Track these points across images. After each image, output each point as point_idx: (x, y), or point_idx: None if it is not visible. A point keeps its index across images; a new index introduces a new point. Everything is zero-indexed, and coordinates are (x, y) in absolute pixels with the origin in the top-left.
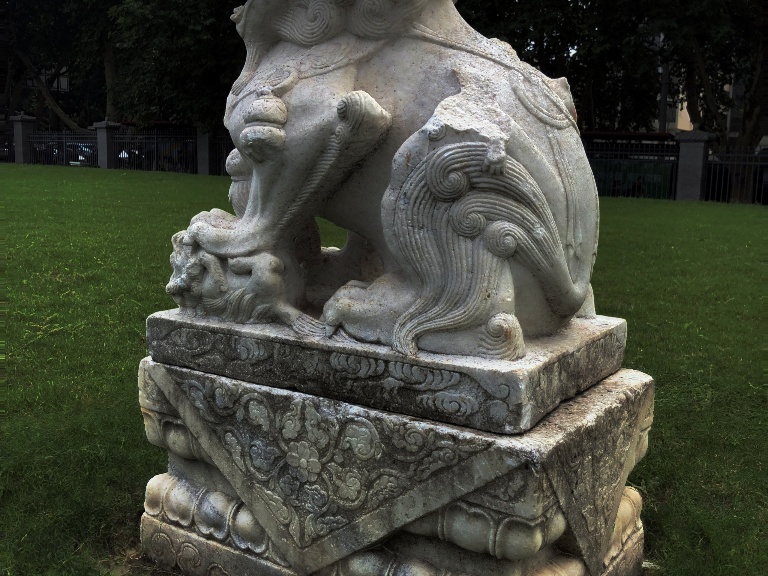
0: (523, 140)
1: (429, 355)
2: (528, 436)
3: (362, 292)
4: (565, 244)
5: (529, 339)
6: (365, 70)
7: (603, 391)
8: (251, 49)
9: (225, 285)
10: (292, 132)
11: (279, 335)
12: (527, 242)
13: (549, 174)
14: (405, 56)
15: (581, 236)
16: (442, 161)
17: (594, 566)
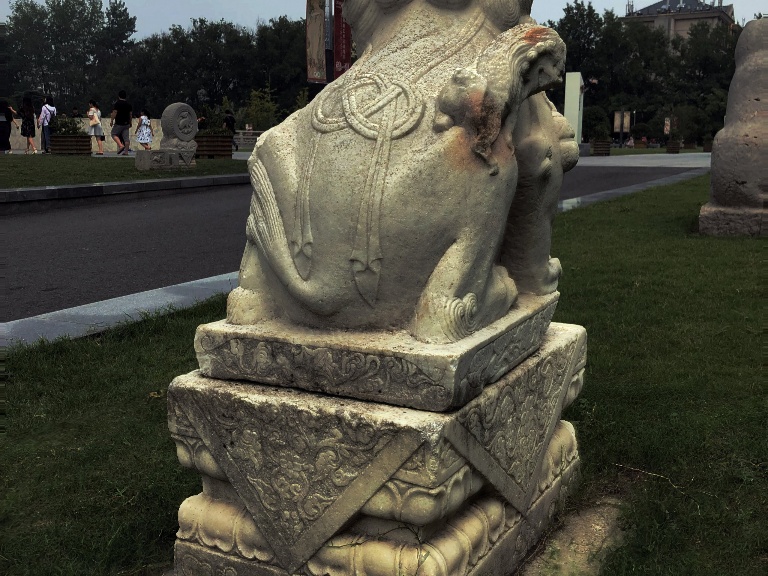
0: (271, 146)
1: None
2: (200, 378)
3: None
4: (291, 240)
5: (290, 322)
6: None
7: (342, 403)
8: None
9: None
10: None
11: None
12: (254, 232)
13: (282, 175)
14: None
15: (310, 236)
16: None
17: (282, 550)
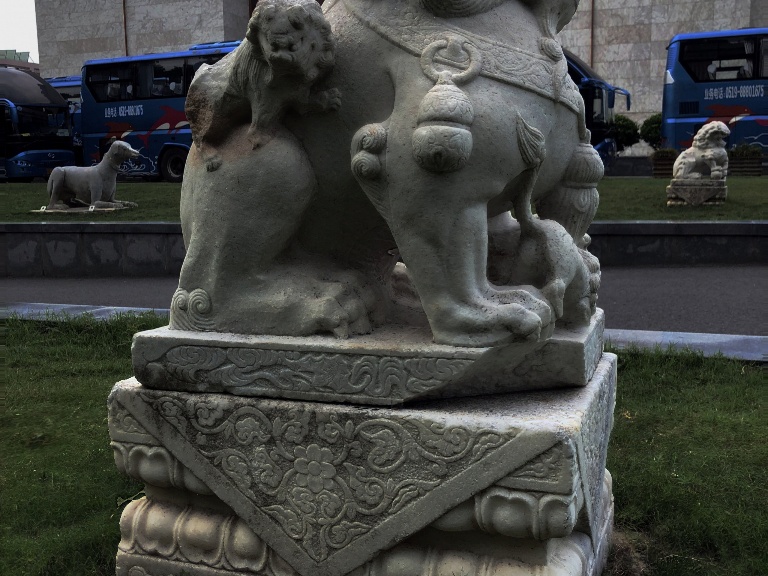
0: None
1: None
2: None
3: None
4: None
5: None
6: None
7: None
8: None
9: None
10: None
11: None
12: None
13: None
14: None
15: None
16: None
17: None
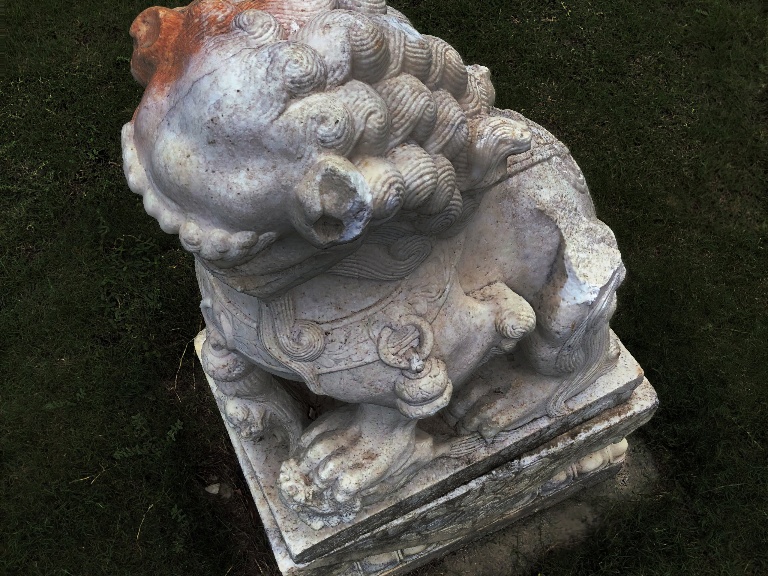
0: None
1: (575, 401)
2: None
3: (505, 401)
4: None
5: None
6: (461, 260)
7: None
8: (281, 302)
9: (390, 488)
10: (456, 374)
11: (451, 473)
12: None
13: None
14: (487, 220)
15: None
16: (601, 312)
17: None
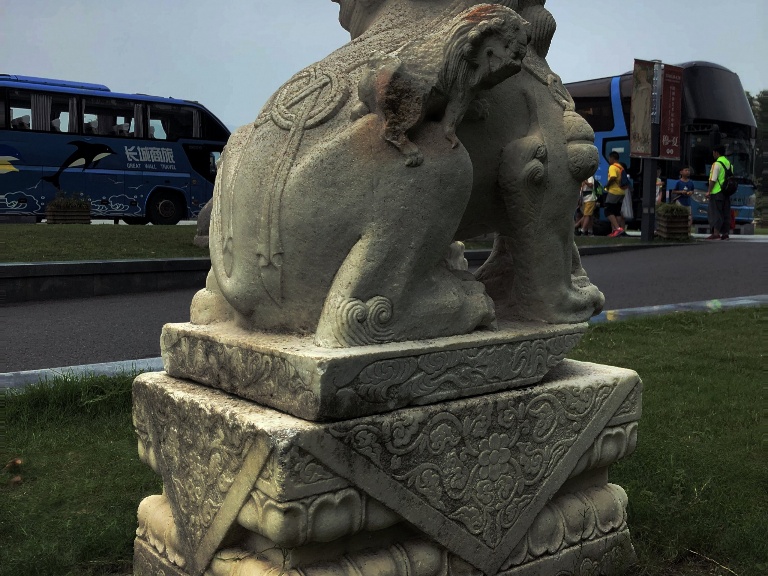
0: None
1: None
2: None
3: None
4: None
5: (235, 324)
6: None
7: None
8: None
9: None
10: None
11: None
12: None
13: None
14: None
15: (231, 231)
16: None
17: None
